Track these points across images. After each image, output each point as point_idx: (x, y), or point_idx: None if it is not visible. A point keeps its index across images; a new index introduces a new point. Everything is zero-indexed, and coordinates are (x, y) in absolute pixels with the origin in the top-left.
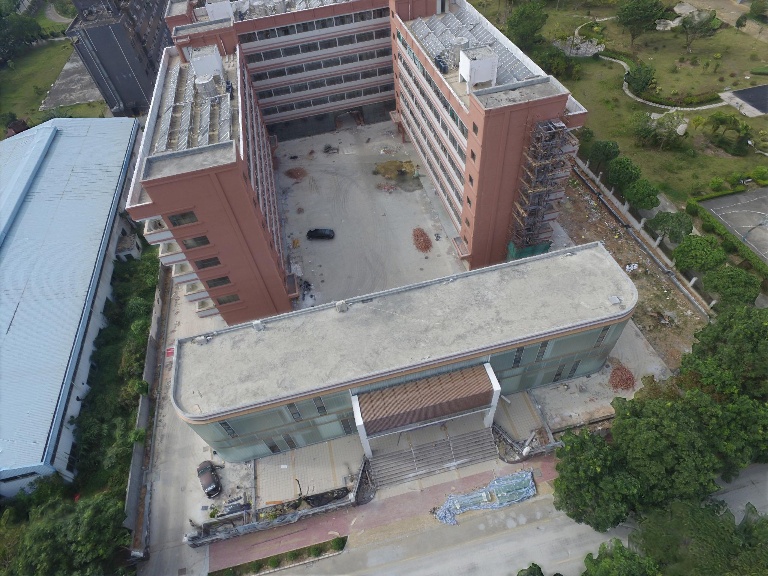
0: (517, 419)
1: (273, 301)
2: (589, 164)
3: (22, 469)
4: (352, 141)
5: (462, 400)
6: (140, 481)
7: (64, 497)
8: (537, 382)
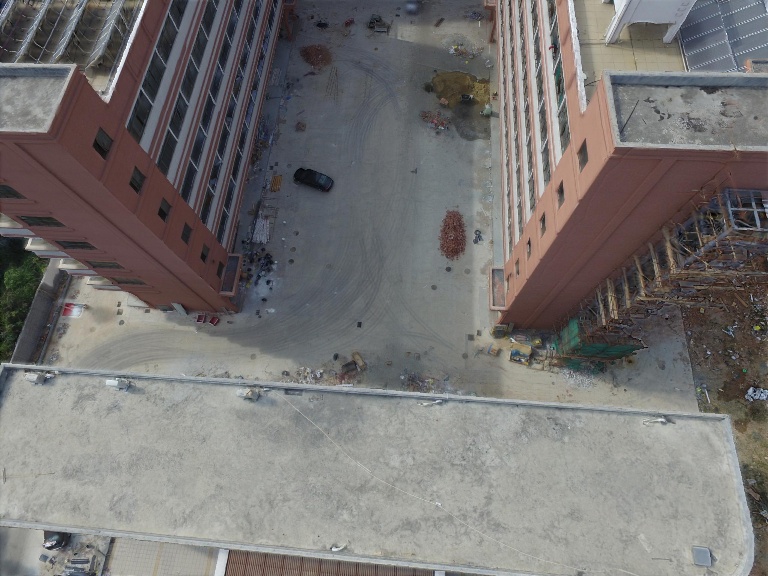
0: None
1: (198, 293)
2: None
3: None
4: (416, 17)
5: None
6: None
7: None
8: None
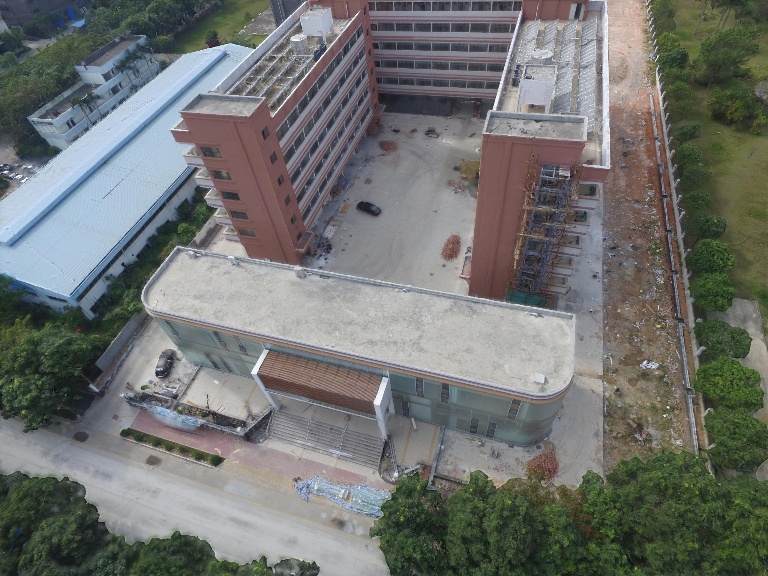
0: (414, 446)
1: (283, 249)
2: (687, 235)
3: (57, 294)
4: (457, 131)
5: (345, 398)
6: (128, 341)
7: (81, 327)
8: (452, 424)
